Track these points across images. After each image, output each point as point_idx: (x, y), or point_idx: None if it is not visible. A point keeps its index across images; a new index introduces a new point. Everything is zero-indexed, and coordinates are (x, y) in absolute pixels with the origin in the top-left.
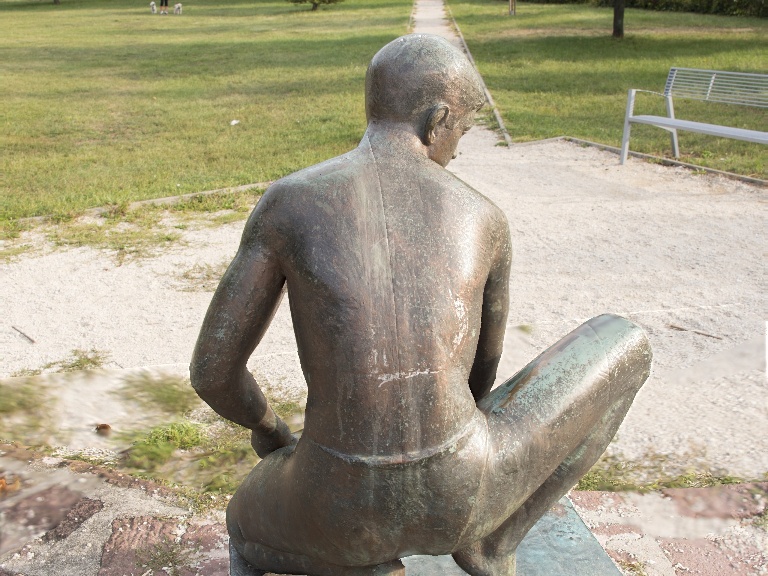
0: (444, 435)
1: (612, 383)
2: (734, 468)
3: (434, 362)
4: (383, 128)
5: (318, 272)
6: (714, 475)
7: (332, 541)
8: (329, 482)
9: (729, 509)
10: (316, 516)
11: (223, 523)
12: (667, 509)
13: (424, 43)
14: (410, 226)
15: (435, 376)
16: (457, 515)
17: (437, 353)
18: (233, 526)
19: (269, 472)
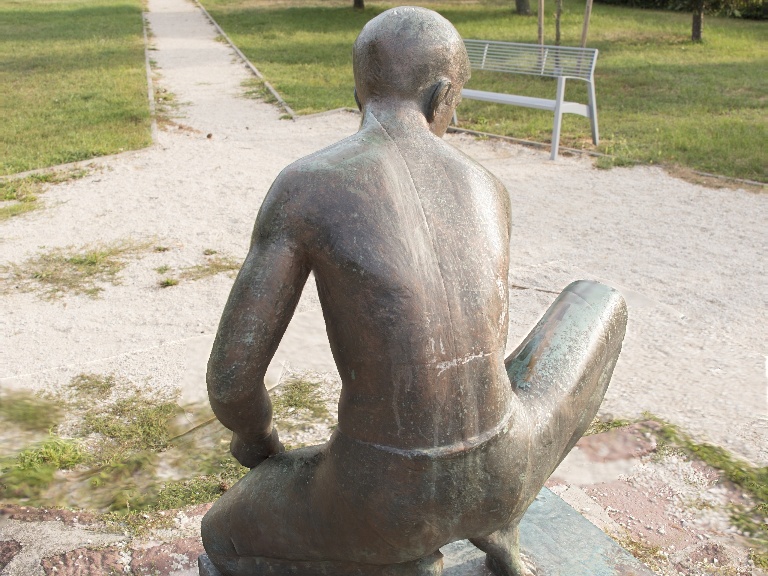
0: (498, 417)
1: (607, 346)
2: (616, 412)
3: (487, 344)
4: (389, 107)
5: (364, 263)
6: (602, 420)
7: (389, 541)
8: (386, 481)
9: (629, 450)
10: (372, 518)
11: (171, 542)
12: (579, 458)
13: (422, 17)
14: (445, 208)
15: (488, 358)
16: (511, 494)
17: (488, 335)
18: (219, 543)
19: (288, 480)
